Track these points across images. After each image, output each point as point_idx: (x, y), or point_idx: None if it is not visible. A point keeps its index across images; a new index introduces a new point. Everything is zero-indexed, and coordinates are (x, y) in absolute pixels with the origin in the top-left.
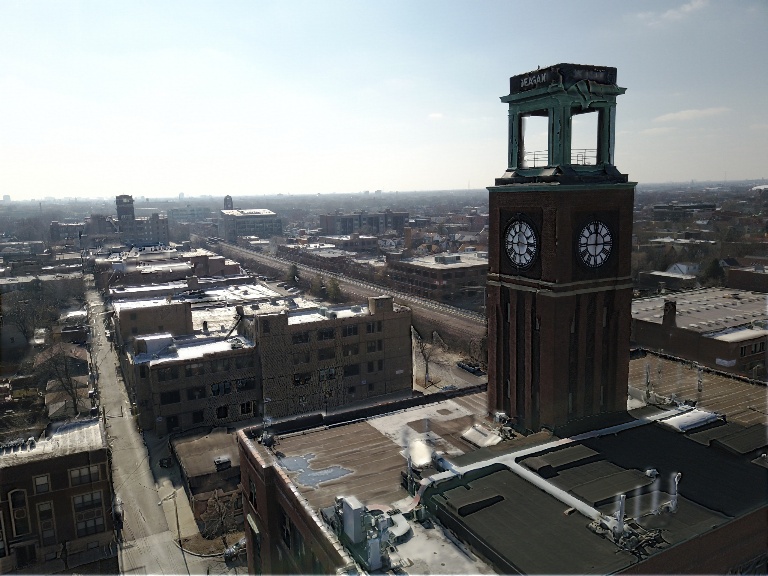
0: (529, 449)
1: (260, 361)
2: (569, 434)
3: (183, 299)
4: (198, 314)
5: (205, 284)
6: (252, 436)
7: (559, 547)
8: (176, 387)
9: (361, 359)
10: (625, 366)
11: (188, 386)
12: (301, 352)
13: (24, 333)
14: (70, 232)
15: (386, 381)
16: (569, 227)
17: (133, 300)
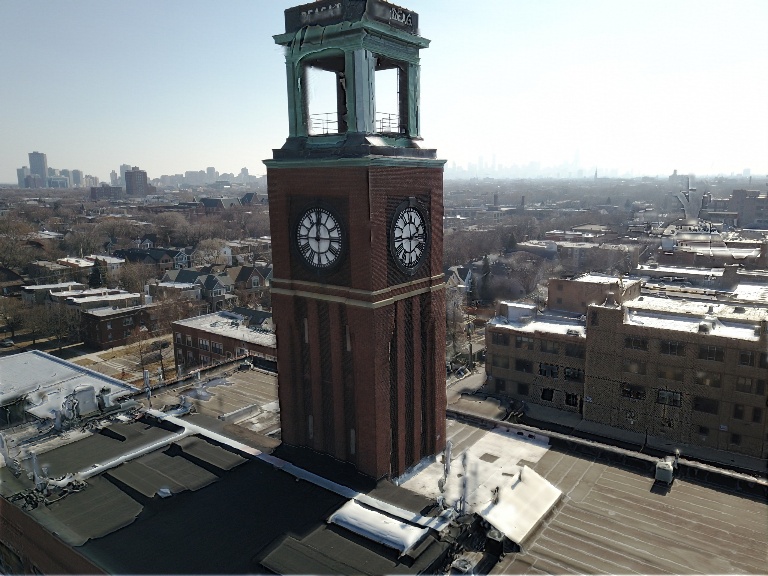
0: (220, 436)
1: (585, 354)
2: (284, 455)
3: (662, 284)
4: (663, 303)
5: (746, 276)
6: None
7: None
8: (506, 354)
9: (724, 396)
10: (369, 415)
11: (517, 356)
12: (636, 360)
13: (524, 288)
14: (632, 205)
15: (765, 441)
16: (287, 213)
17: (609, 275)
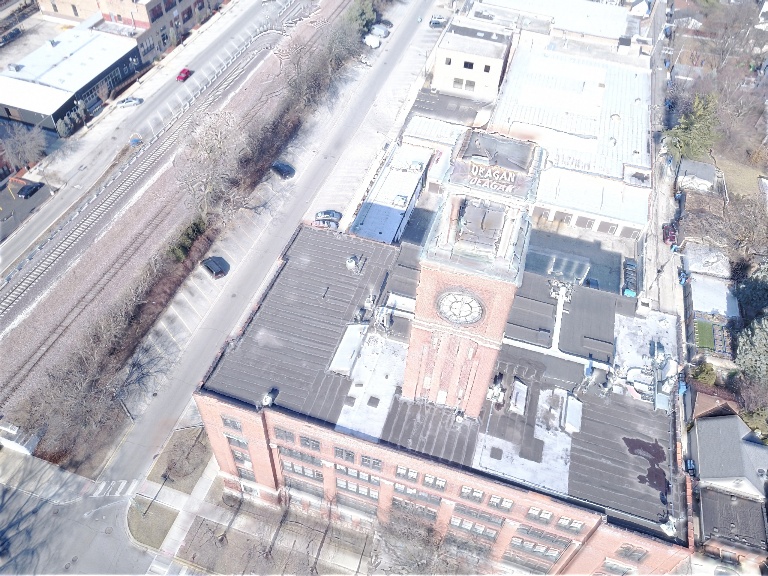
0: (532, 348)
1: None
2: None
3: None
4: None
5: None
6: (679, 542)
7: (592, 307)
8: None
9: None
10: None
11: None
12: None
13: None
14: None
15: None
16: None
17: None
